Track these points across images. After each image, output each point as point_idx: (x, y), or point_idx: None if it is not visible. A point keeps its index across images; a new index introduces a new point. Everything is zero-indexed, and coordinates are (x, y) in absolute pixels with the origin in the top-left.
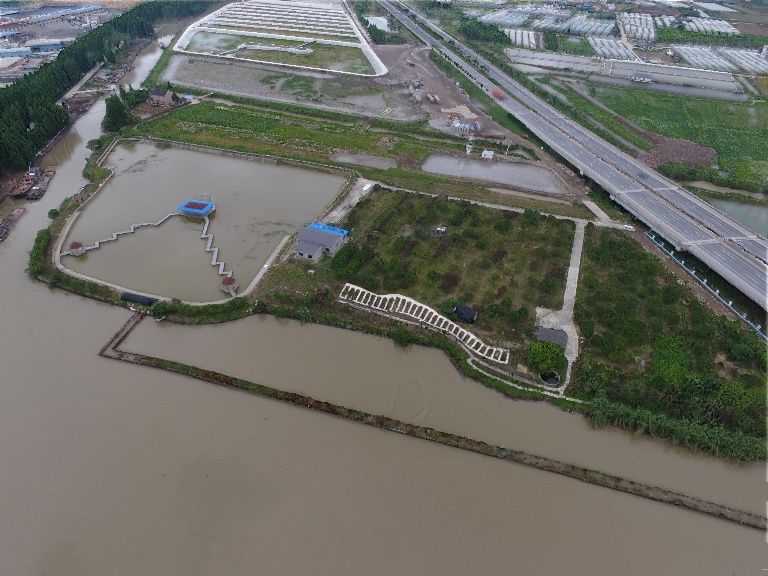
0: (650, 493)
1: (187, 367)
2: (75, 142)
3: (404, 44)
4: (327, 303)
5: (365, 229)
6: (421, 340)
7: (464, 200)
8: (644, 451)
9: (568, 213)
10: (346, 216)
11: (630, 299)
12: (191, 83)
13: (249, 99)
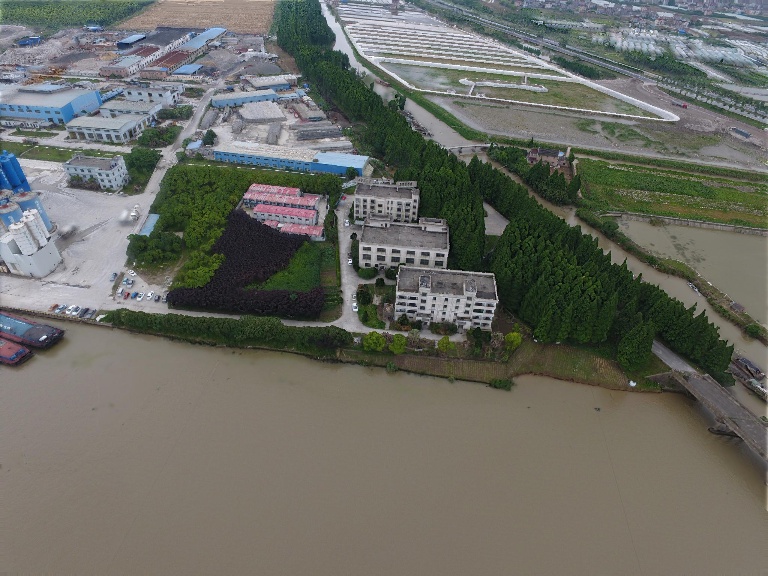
0: None
1: None
2: None
3: (616, 79)
4: None
5: None
6: None
7: None
8: None
9: None
10: None
11: None
12: (516, 134)
13: (620, 155)
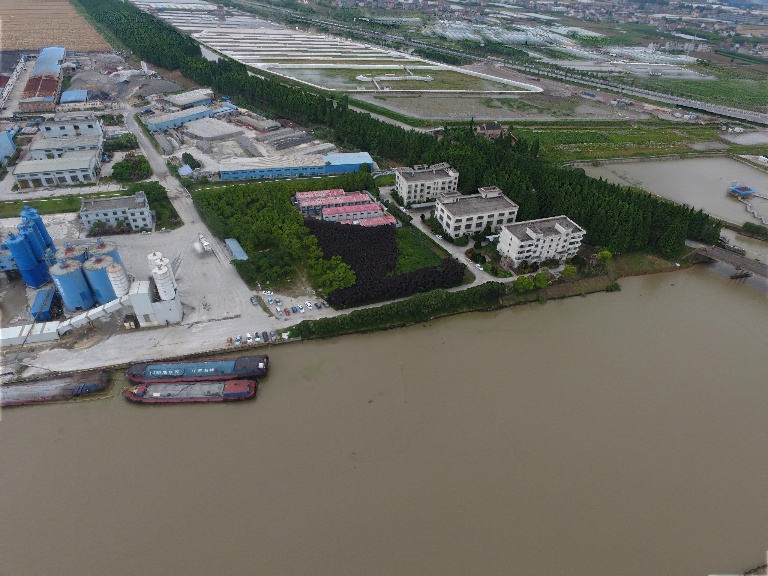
0: None
1: None
2: None
3: None
4: None
5: None
6: None
7: None
8: None
9: None
10: None
11: None
12: (448, 117)
13: (532, 122)
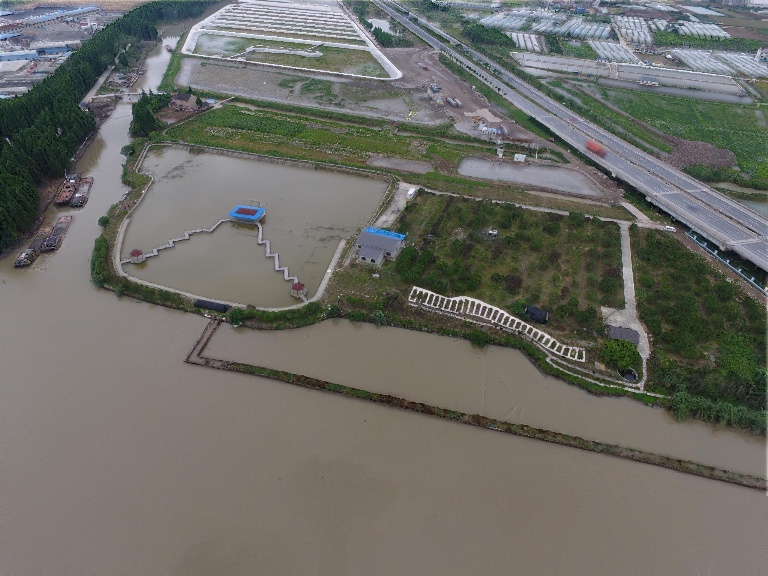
0: (743, 481)
1: (276, 372)
2: (101, 148)
3: (412, 47)
4: (398, 306)
5: (420, 233)
6: (497, 341)
7: (509, 203)
8: (728, 441)
9: (609, 215)
10: (397, 220)
11: (689, 297)
12: (209, 87)
13: (271, 103)
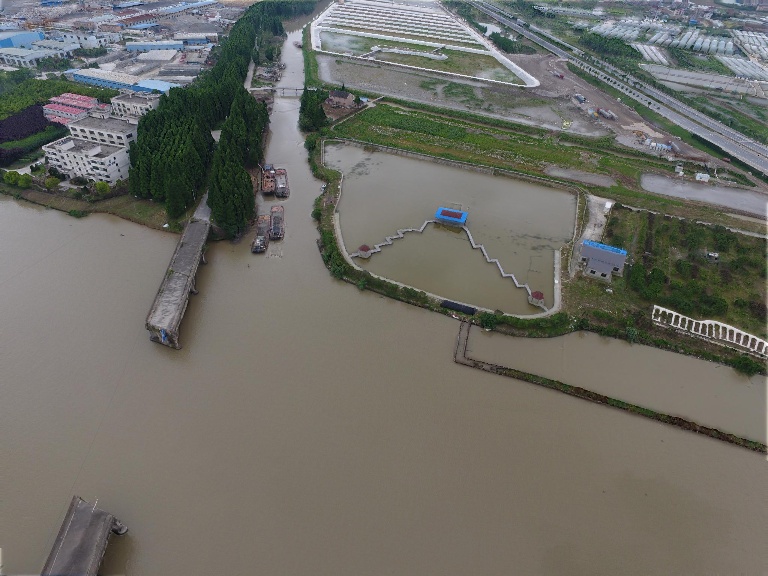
0: None
1: (551, 381)
2: (270, 139)
3: (535, 54)
4: None
5: (637, 250)
6: (766, 371)
7: None
8: None
9: None
10: (604, 234)
11: None
12: (353, 85)
13: (422, 105)
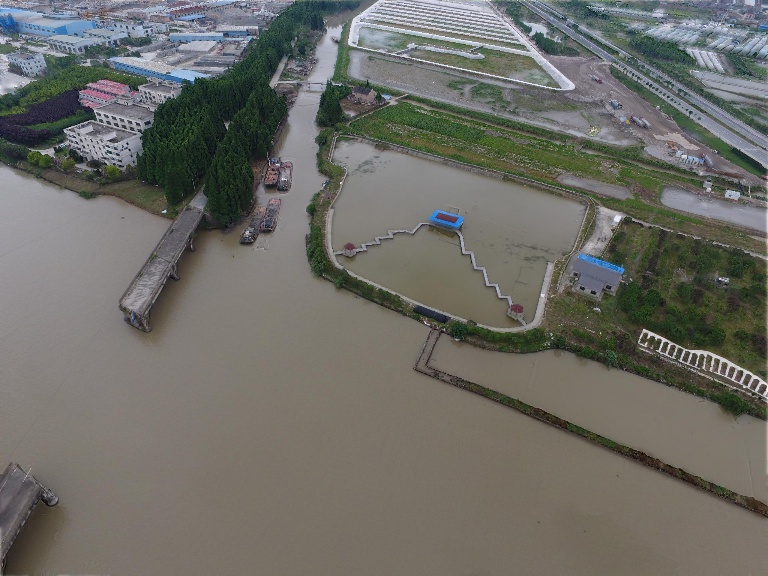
0: None
1: (511, 399)
2: (288, 132)
3: (577, 56)
4: None
5: (637, 268)
6: (755, 411)
7: None
8: None
9: None
10: (606, 249)
11: None
12: (380, 82)
13: (445, 105)
